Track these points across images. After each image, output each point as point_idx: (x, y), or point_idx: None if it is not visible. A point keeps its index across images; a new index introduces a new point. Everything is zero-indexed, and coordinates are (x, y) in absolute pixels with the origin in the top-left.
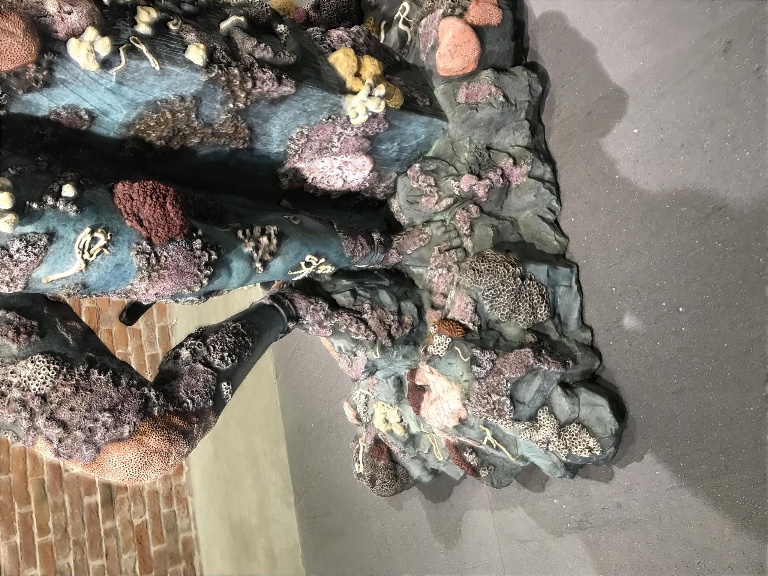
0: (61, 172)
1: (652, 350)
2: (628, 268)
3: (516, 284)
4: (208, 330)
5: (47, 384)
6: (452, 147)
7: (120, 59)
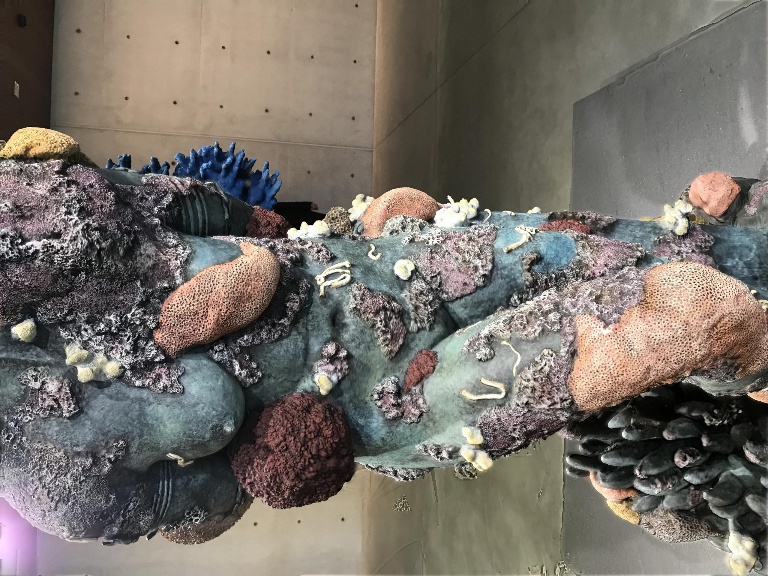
0: None
1: None
2: None
3: None
4: None
5: None
6: None
7: (487, 213)
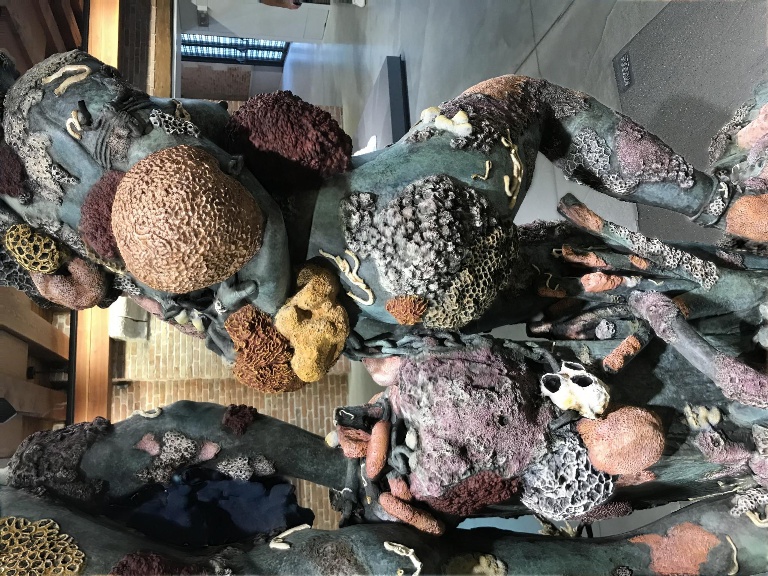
0: None
1: None
2: None
3: None
4: None
5: None
6: None
7: None
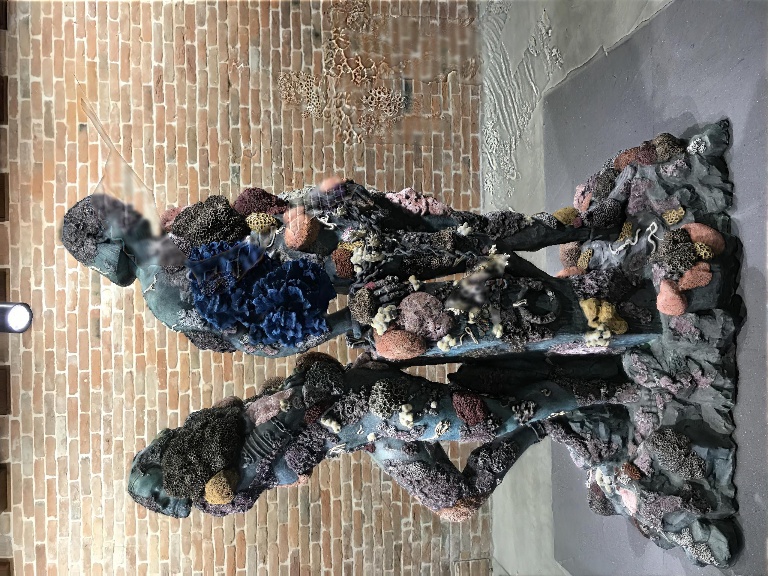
0: (431, 392)
1: (766, 522)
2: (764, 467)
3: (680, 458)
4: (493, 445)
5: (420, 476)
6: (662, 350)
7: (460, 343)
